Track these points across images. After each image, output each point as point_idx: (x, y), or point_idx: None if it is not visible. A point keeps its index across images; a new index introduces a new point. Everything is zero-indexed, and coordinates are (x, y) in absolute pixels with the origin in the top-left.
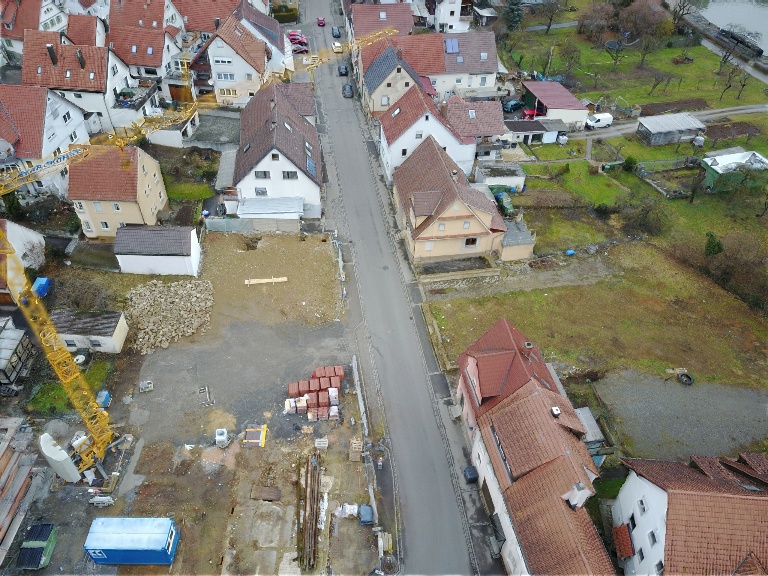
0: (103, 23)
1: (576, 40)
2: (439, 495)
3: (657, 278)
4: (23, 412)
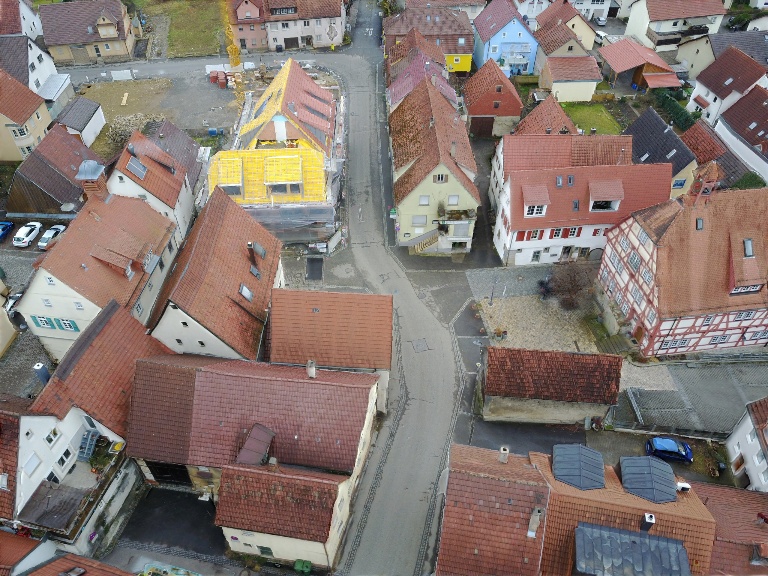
0: None
1: None
2: None
3: (174, 7)
4: None
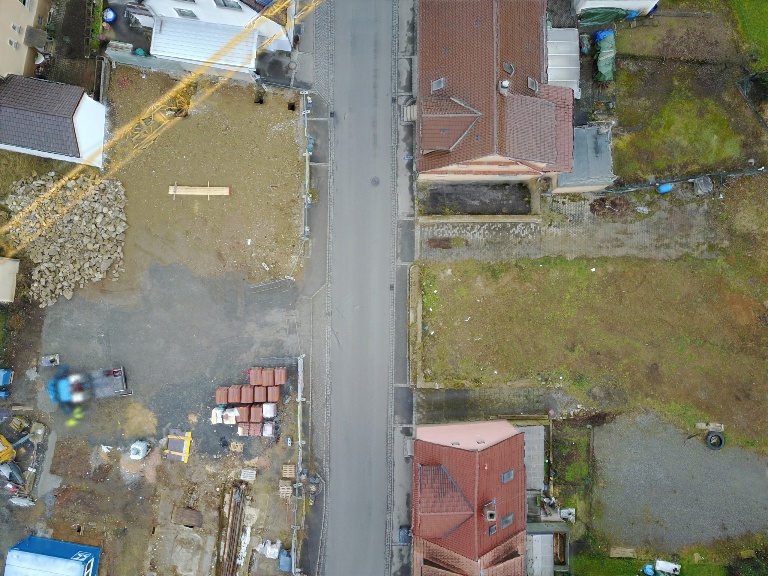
0: None
1: None
2: (368, 545)
3: None
4: None
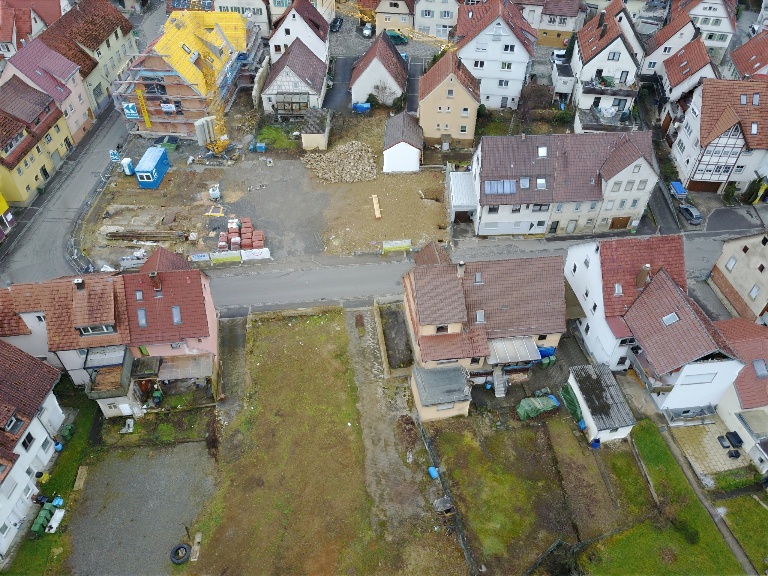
0: (696, 31)
1: None
2: None
3: None
4: None
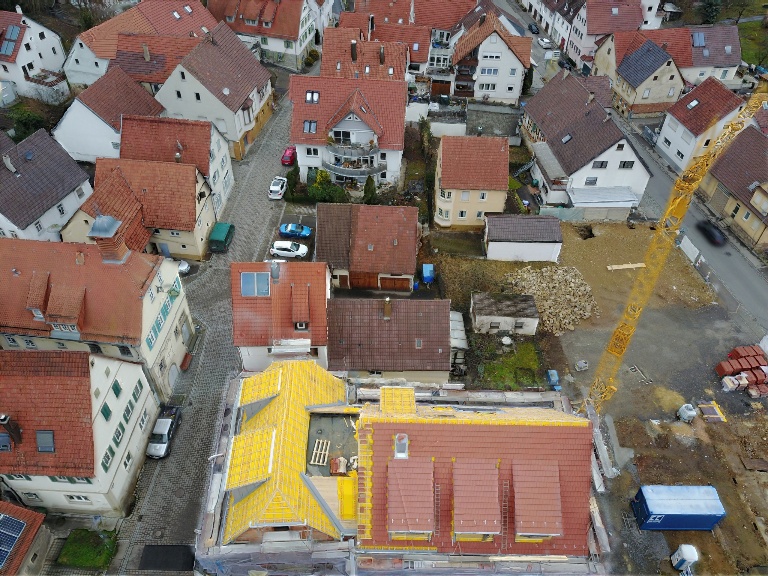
0: (371, 20)
1: (766, 34)
2: None
3: None
4: None
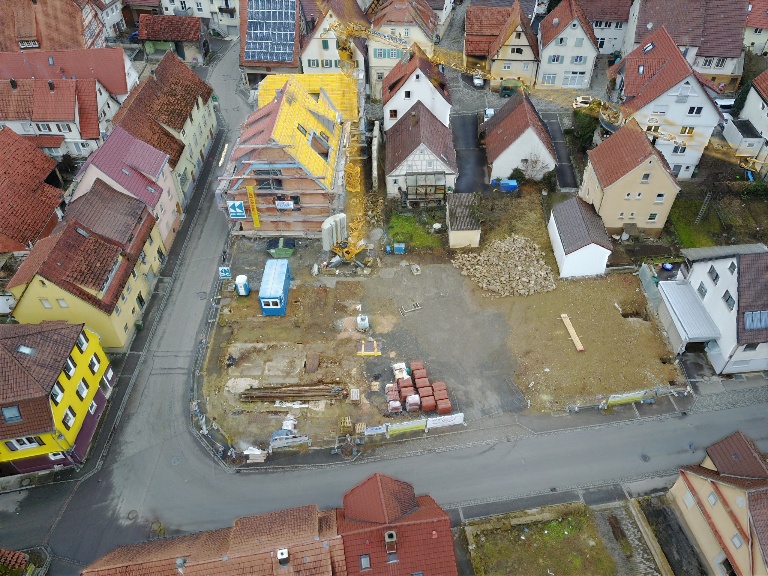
0: None
1: None
2: None
3: None
4: (388, 214)
